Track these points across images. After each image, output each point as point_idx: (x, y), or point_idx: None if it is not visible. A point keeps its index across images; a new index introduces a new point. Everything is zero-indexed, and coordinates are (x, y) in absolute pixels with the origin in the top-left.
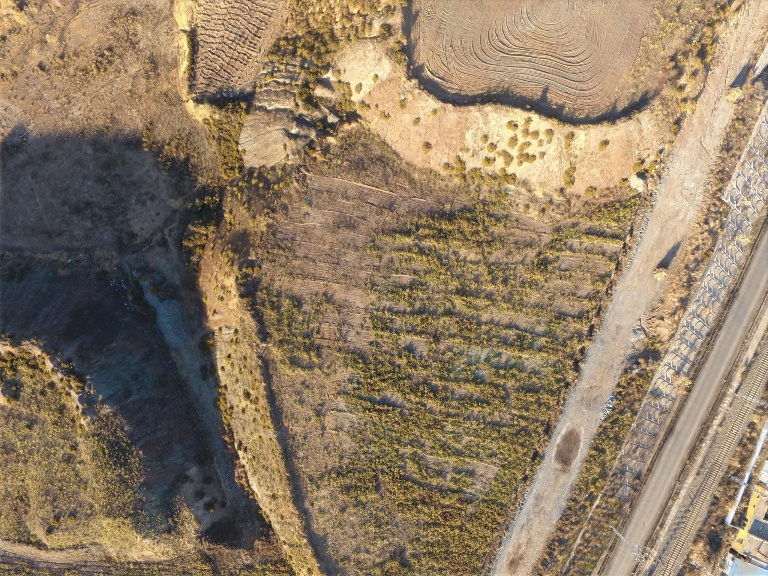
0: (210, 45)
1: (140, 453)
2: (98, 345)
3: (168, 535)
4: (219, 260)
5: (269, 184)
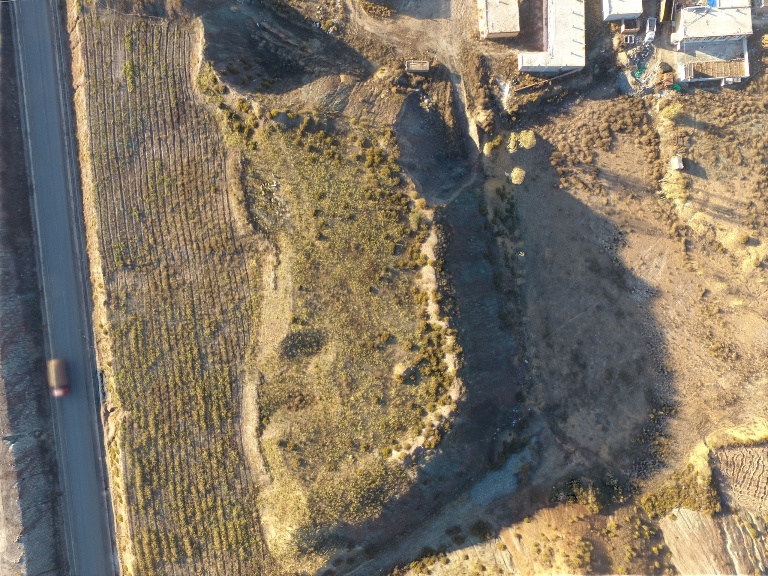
0: (766, 458)
1: (376, 515)
2: (465, 436)
3: (297, 551)
4: (574, 537)
5: (661, 575)
